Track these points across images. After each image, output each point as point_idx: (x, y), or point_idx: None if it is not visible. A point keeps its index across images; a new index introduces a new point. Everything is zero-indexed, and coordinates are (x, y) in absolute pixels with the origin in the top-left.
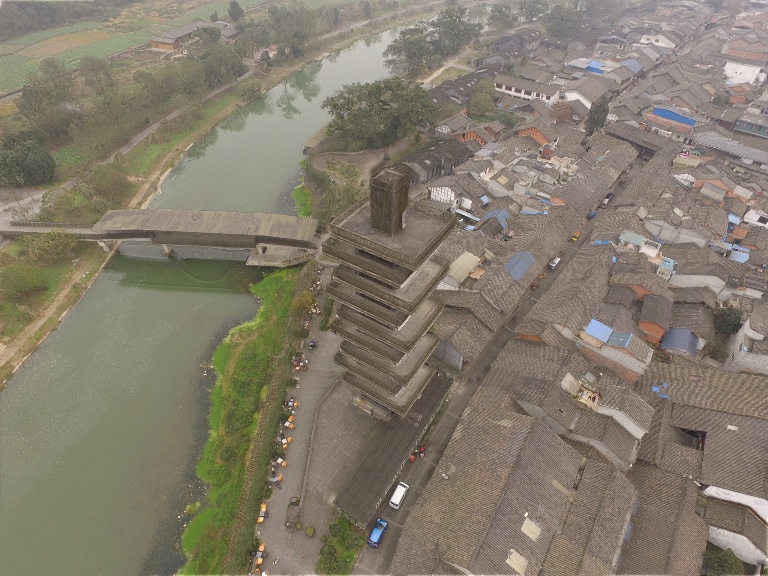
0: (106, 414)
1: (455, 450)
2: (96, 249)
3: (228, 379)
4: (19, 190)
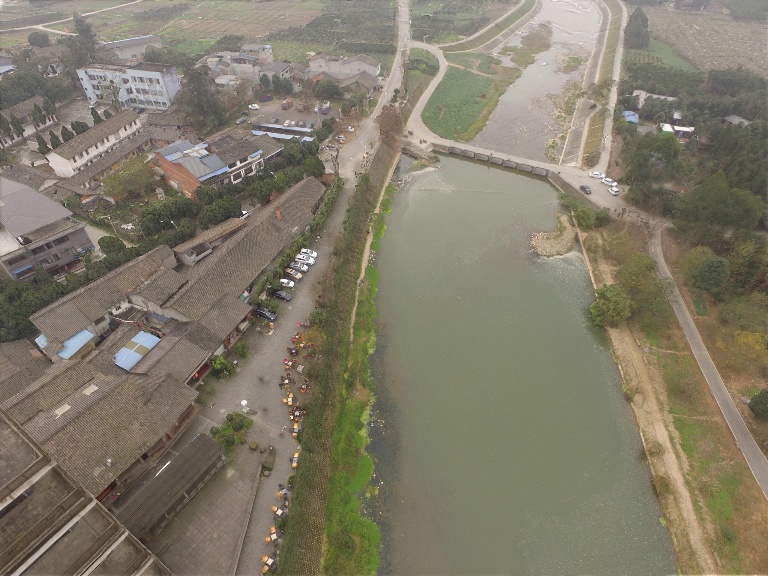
0: None
1: None
2: None
3: None
4: None
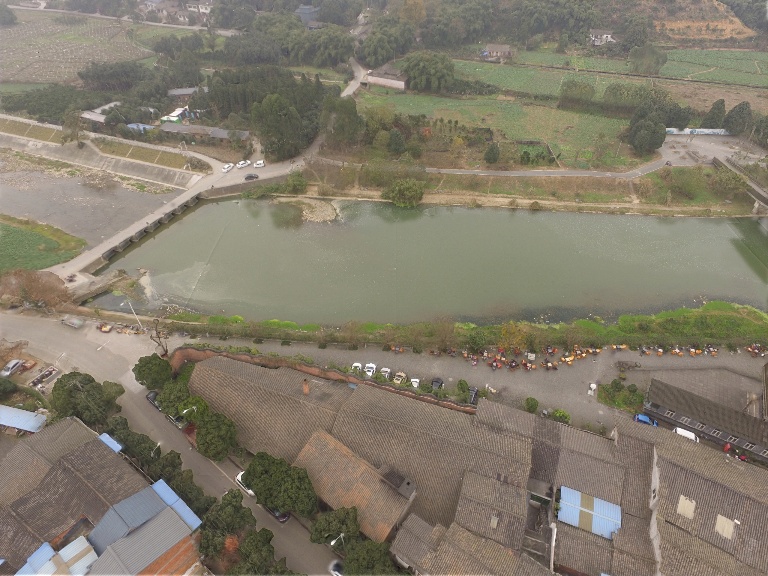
0: (629, 261)
1: (762, 473)
2: (749, 206)
3: (702, 313)
4: (760, 149)
